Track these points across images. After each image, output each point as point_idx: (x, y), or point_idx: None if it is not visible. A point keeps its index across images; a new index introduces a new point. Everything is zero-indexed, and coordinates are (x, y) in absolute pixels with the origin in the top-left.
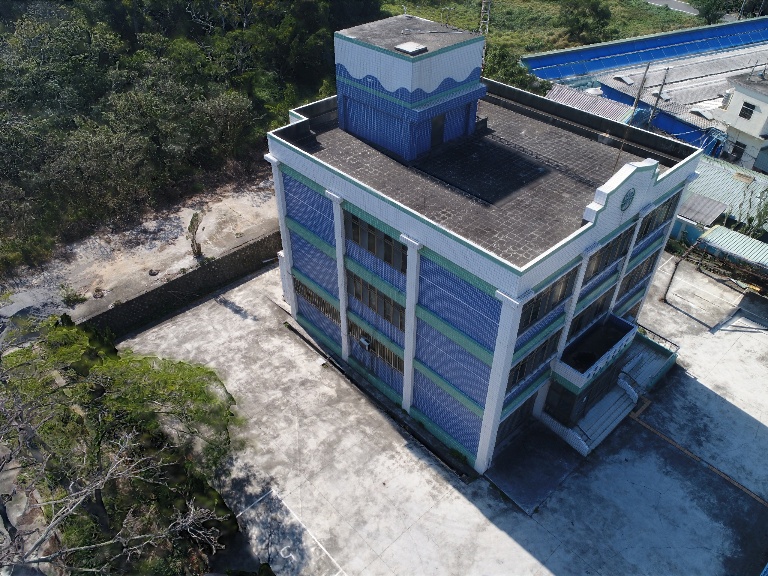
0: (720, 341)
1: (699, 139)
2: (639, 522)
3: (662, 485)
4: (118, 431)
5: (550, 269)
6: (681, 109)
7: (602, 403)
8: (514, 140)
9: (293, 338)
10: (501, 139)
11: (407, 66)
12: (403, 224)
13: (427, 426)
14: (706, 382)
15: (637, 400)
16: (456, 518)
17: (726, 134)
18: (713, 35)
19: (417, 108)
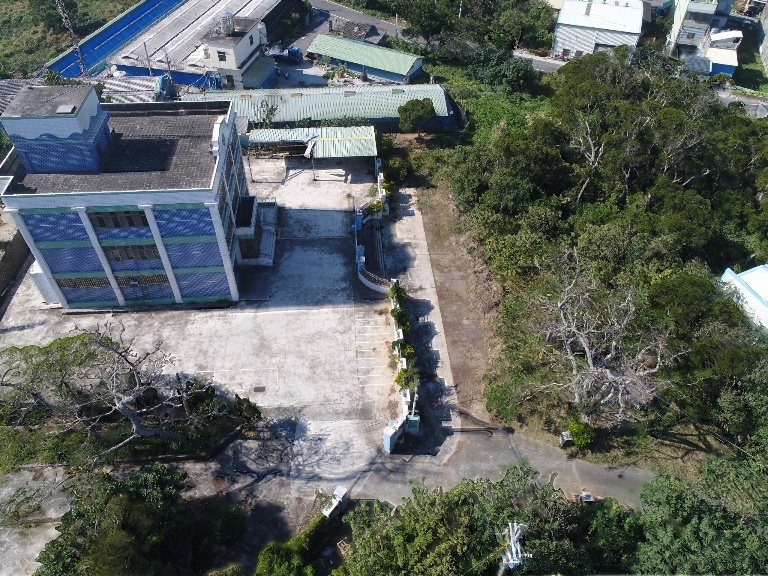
0: (289, 186)
1: (205, 82)
2: (309, 273)
3: (307, 255)
4: (30, 422)
5: (217, 184)
6: (182, 65)
7: (263, 241)
8: (139, 134)
9: (78, 317)
10: (131, 136)
11: (73, 120)
12: (136, 200)
13: (197, 301)
14: (295, 207)
15: (275, 231)
16: (242, 322)
17: (218, 73)
18: None
19: (89, 140)
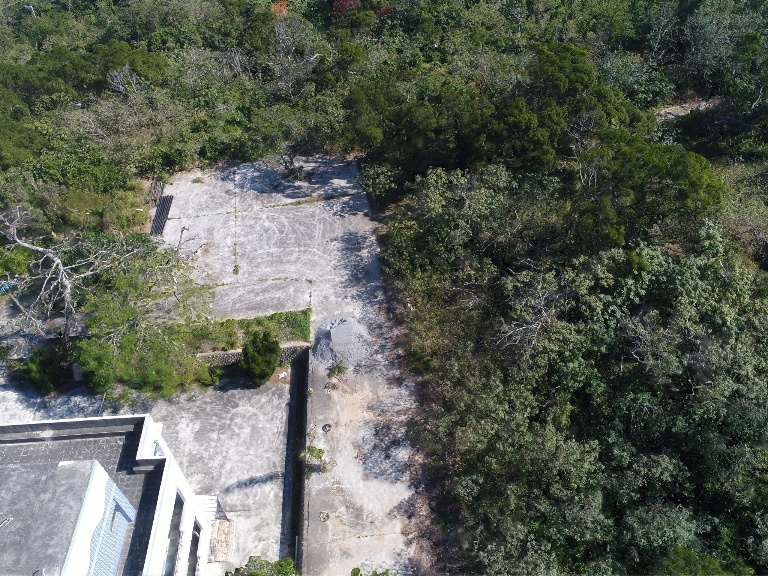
0: None
1: None
2: None
3: None
4: None
5: None
6: None
7: None
8: None
9: None
10: None
11: None
12: None
13: None
14: None
15: None
16: None
17: None
18: None
19: None
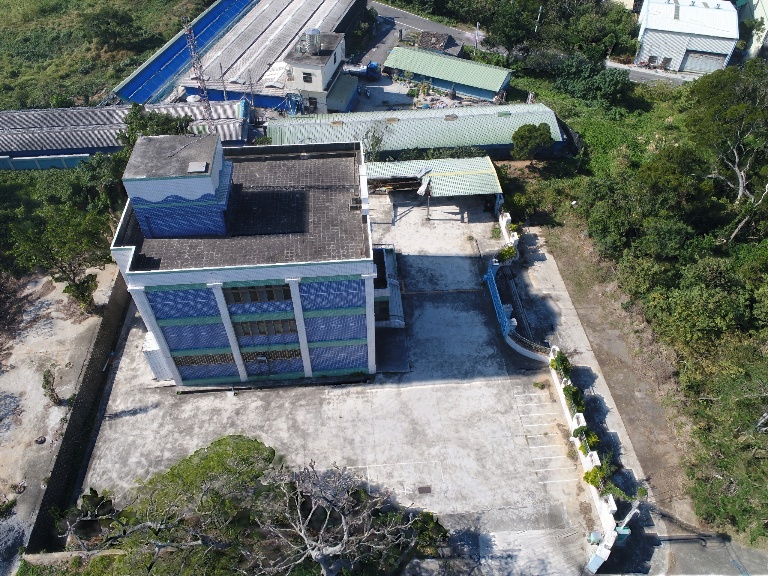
0: (401, 228)
1: None
2: (448, 336)
3: (441, 314)
4: None
5: None
6: (258, 87)
7: None
8: (260, 184)
9: (196, 397)
10: (253, 188)
11: (206, 180)
12: (283, 274)
13: (329, 374)
14: (414, 253)
15: None
16: (386, 400)
17: (300, 95)
18: (220, 11)
19: (220, 201)
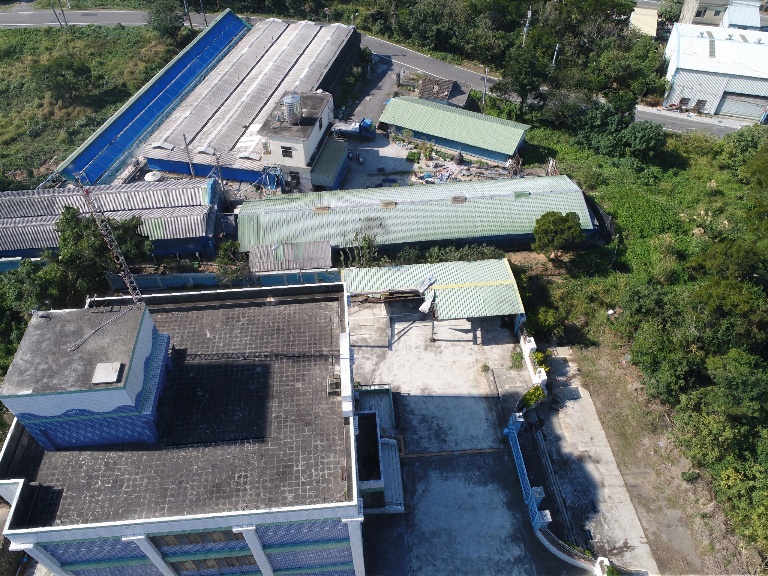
0: (399, 353)
1: None
2: (460, 527)
3: (451, 489)
4: None
5: None
6: (231, 158)
7: (384, 466)
8: (211, 350)
9: None
10: (200, 356)
11: (119, 393)
12: (230, 522)
13: None
14: (415, 392)
15: None
16: None
17: (279, 169)
18: (191, 58)
19: (144, 410)
